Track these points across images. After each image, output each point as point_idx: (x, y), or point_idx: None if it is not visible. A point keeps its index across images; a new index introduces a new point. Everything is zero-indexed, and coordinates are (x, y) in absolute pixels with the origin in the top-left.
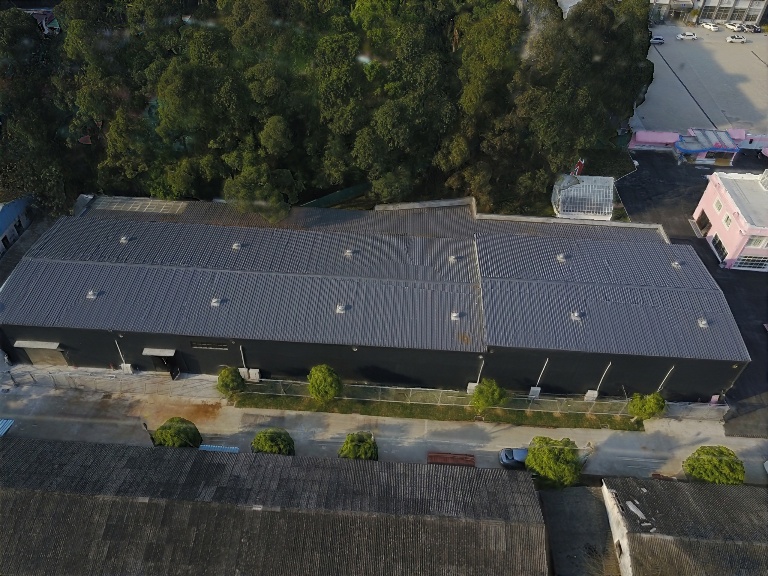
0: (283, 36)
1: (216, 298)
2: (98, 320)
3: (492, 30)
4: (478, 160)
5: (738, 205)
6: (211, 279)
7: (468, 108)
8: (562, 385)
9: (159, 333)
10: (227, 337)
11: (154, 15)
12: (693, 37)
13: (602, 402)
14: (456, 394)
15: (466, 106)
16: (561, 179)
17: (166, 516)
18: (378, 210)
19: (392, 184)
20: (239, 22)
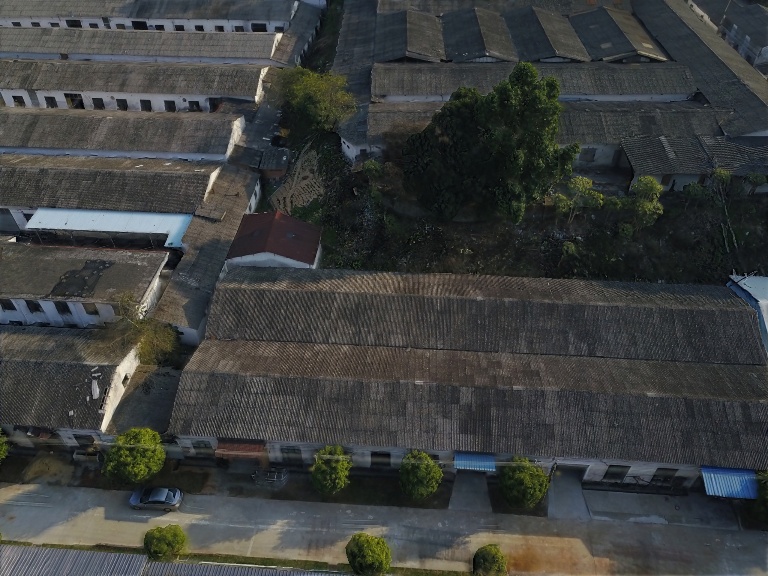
0: None
1: None
2: None
3: None
4: None
5: None
6: None
7: None
8: None
9: None
10: None
11: None
12: None
13: None
14: None
15: None
16: None
17: (494, 380)
18: None
19: None
20: None
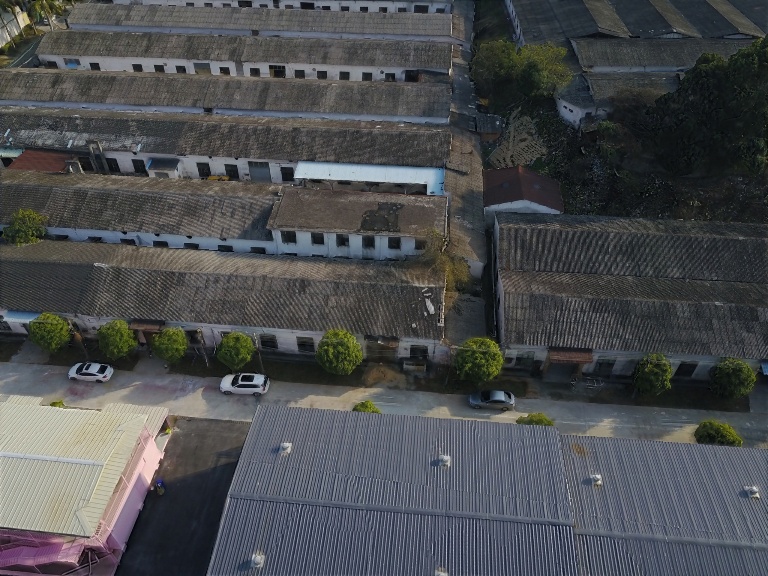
0: None
1: None
2: None
3: None
4: None
5: None
6: None
7: None
8: None
9: None
10: None
11: None
12: None
13: None
14: None
15: None
16: None
17: None
18: None
19: None
20: None
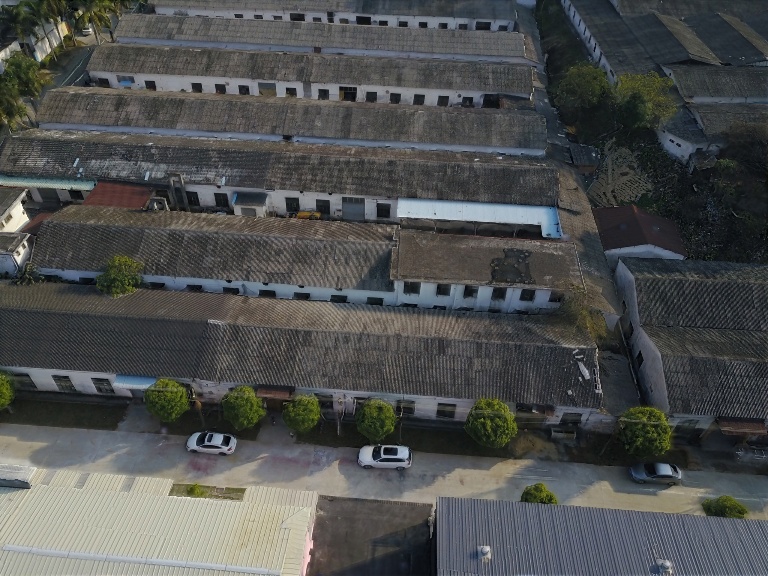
0: None
1: None
2: None
3: None
4: None
5: None
6: None
7: None
8: None
9: None
10: None
11: None
12: None
13: None
14: None
15: None
16: None
17: None
18: None
19: None
20: None
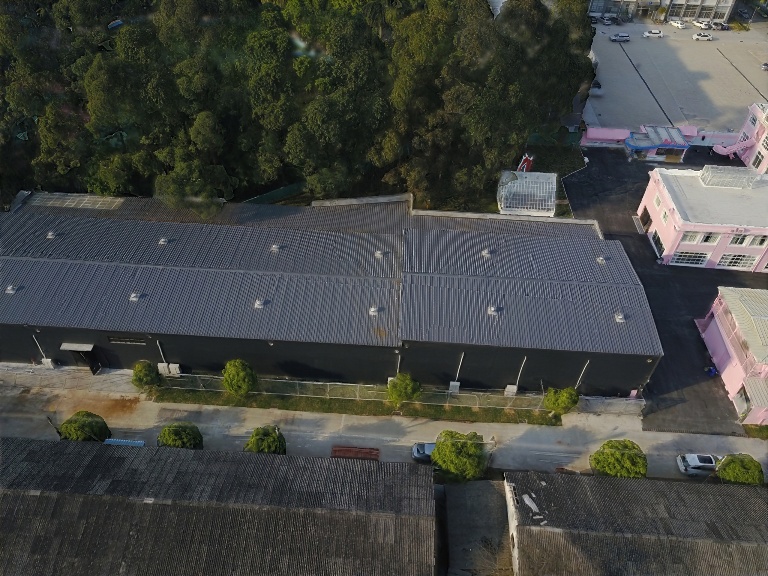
0: (210, 31)
1: (135, 293)
2: (14, 315)
3: (419, 25)
4: (417, 156)
5: (675, 201)
6: (132, 274)
7: (398, 104)
8: (481, 380)
9: (74, 328)
10: (142, 332)
11: (78, 10)
12: (659, 35)
13: (522, 397)
14: (376, 389)
15: (396, 102)
16: (499, 175)
17: (56, 509)
18: (315, 206)
19: (326, 180)
20: (166, 18)
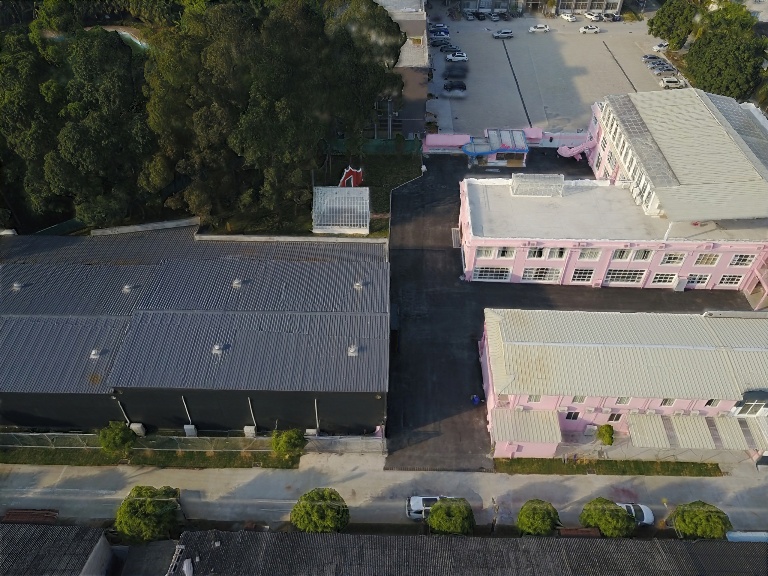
0: None
1: None
2: None
3: (162, 44)
4: None
5: (476, 214)
6: None
7: (152, 127)
8: (218, 422)
9: None
10: None
11: None
12: (545, 29)
13: None
14: None
15: (151, 125)
16: (289, 194)
17: None
18: (95, 235)
19: (95, 209)
20: None
